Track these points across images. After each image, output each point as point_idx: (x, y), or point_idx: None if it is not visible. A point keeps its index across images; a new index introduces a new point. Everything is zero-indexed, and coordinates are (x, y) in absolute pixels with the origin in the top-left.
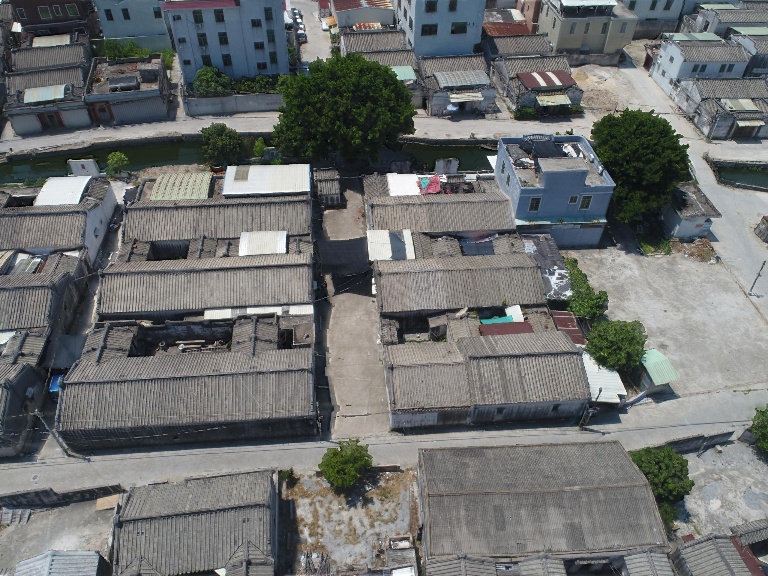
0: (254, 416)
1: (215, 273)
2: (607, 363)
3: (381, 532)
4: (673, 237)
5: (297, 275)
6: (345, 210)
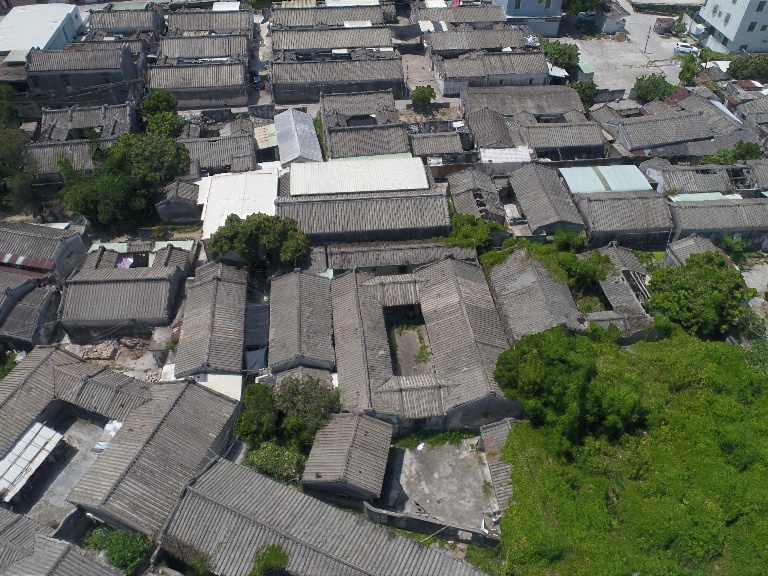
0: (373, 78)
1: (336, 31)
2: (558, 62)
3: None
4: (603, 32)
5: (383, 32)
6: (399, 24)
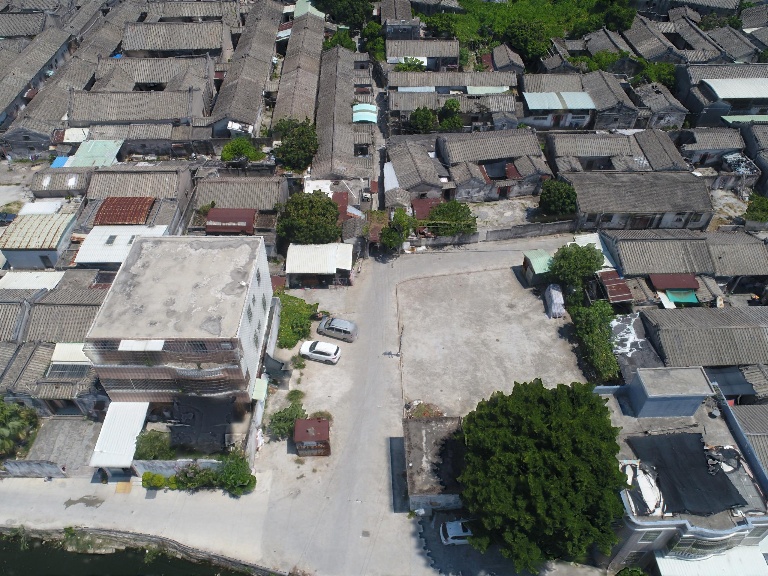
0: None
1: None
2: None
3: (714, 206)
4: None
5: None
6: None
